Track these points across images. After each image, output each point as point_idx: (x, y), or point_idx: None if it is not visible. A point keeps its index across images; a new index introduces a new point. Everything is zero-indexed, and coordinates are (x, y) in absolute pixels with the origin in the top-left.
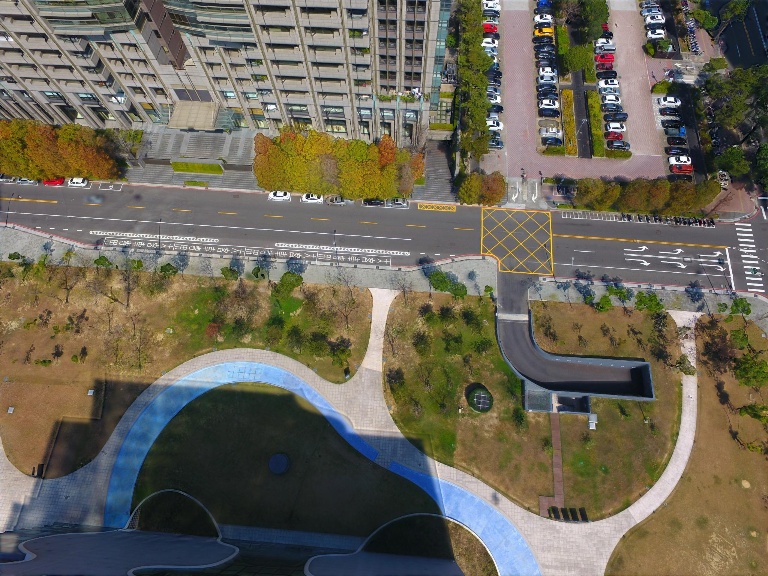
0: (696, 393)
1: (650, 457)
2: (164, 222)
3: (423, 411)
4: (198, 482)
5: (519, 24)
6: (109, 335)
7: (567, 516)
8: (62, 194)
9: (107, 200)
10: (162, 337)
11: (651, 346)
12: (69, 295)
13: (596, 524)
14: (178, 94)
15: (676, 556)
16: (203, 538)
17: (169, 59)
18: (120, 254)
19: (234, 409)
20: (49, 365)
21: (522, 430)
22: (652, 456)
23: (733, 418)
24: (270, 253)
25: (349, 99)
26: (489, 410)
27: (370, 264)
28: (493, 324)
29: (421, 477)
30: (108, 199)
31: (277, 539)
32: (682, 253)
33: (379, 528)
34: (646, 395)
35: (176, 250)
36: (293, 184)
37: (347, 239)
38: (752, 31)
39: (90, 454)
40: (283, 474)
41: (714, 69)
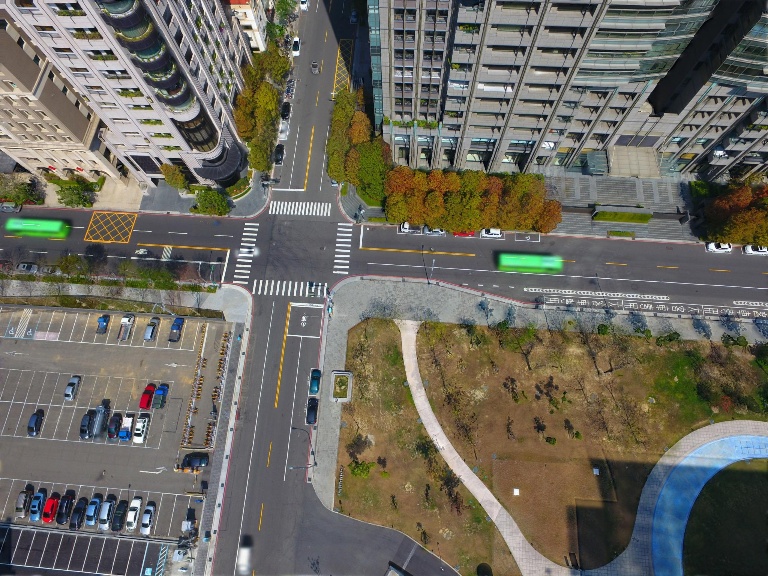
0: None
1: None
2: (601, 277)
3: None
4: (752, 573)
5: None
6: (588, 406)
7: None
8: (477, 246)
9: (529, 253)
10: (647, 408)
11: None
12: (529, 361)
13: None
14: (619, 140)
15: None
16: None
17: None
18: (568, 314)
19: (759, 489)
20: (536, 440)
21: None
22: None
23: None
24: (731, 312)
25: None
26: None
27: None
28: None
29: None
30: (530, 251)
31: None
32: None
33: None
34: None
35: (627, 309)
36: (763, 239)
37: None
38: None
39: (621, 541)
40: None
41: None
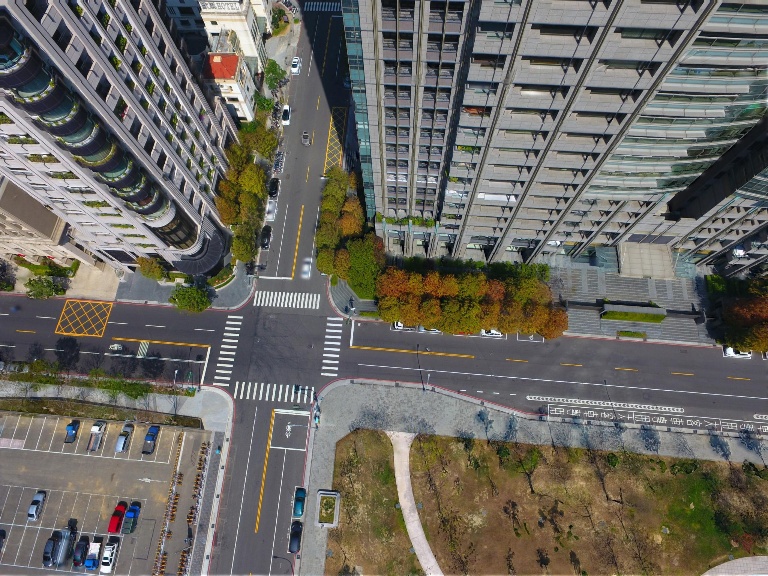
0: None
1: None
2: (611, 385)
3: None
4: None
5: None
6: (596, 536)
7: None
8: (476, 346)
9: (533, 355)
10: (660, 539)
11: None
12: (532, 482)
13: None
14: (631, 237)
15: None
16: None
17: None
18: (574, 427)
19: None
20: None
21: None
22: None
23: None
24: (752, 428)
25: None
26: None
27: None
28: None
29: None
30: (533, 353)
31: None
32: None
33: None
34: None
35: (638, 422)
36: None
37: None
38: None
39: None
40: None
41: None
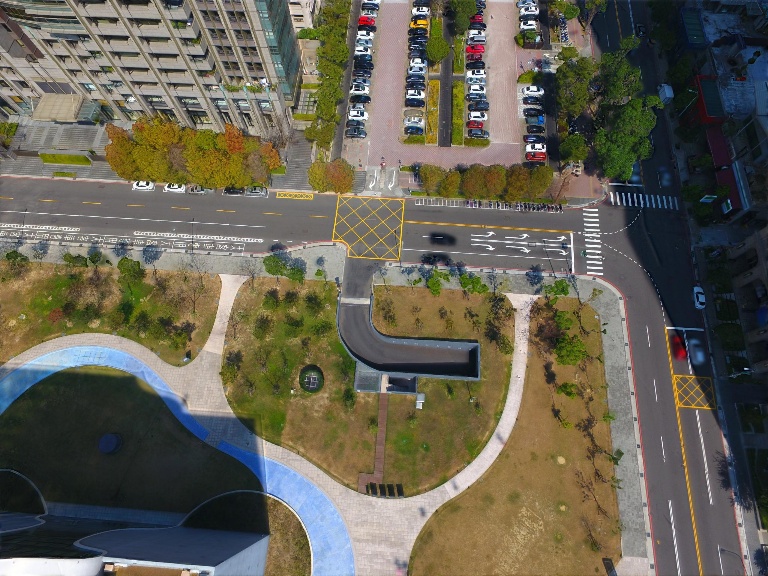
0: (524, 373)
1: (471, 435)
2: (29, 212)
3: (257, 392)
4: (32, 462)
5: (397, 17)
6: None
7: (384, 492)
8: None
9: None
10: (14, 323)
11: (486, 328)
12: None
13: (411, 499)
14: (41, 87)
15: (484, 530)
16: (26, 515)
17: (27, 52)
18: None
19: (75, 392)
20: None
21: (350, 410)
22: (473, 434)
23: (557, 397)
24: (128, 241)
25: (199, 90)
26: (318, 390)
27: (223, 251)
28: (335, 308)
29: (248, 455)
30: None
31: (101, 516)
32: (527, 238)
33: (200, 504)
34: (472, 375)
35: (37, 239)
36: (148, 173)
37: (204, 227)
38: (624, 21)
39: None
40: (114, 453)
41: (566, 58)
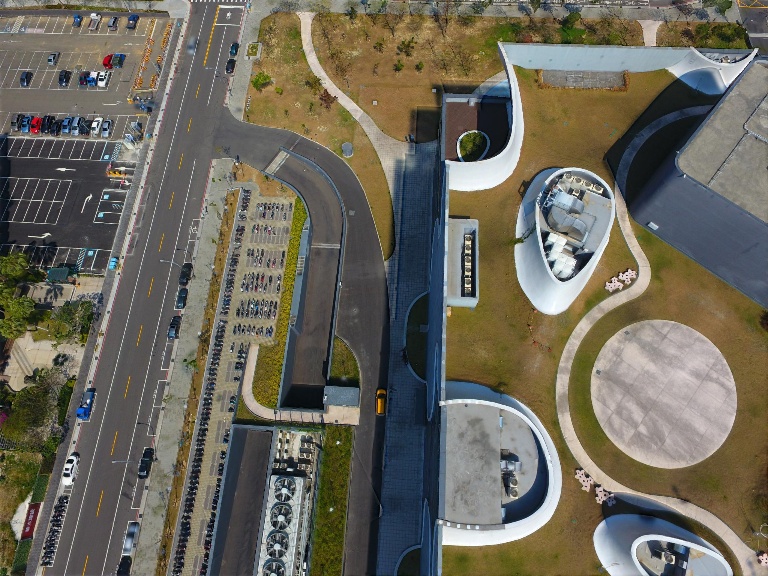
0: None
1: None
2: None
3: None
4: None
5: None
6: (434, 57)
7: None
8: None
9: None
10: (478, 57)
11: None
12: (394, 32)
13: None
14: None
15: None
16: None
17: None
18: (426, 5)
19: None
20: (393, 76)
21: None
22: None
23: None
24: (549, 1)
25: None
26: None
27: (633, 5)
28: (743, 40)
29: None
30: None
31: None
32: None
33: None
34: None
35: (471, 1)
36: None
37: None
38: None
39: None
40: None
41: None
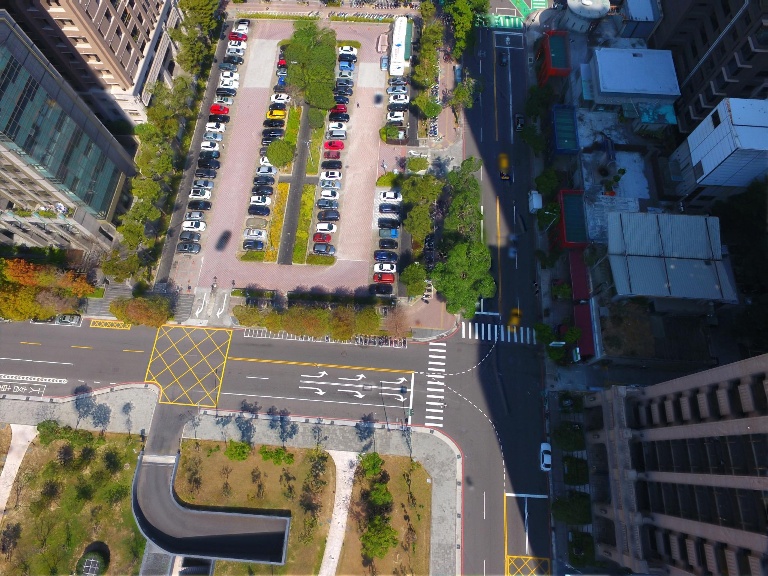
0: (339, 552)
1: None
2: None
3: None
4: None
5: (254, 104)
6: None
7: None
8: None
9: None
10: None
11: (302, 495)
12: None
13: None
14: None
15: None
16: None
17: None
18: None
19: None
20: None
21: None
22: None
23: None
24: None
25: None
26: None
27: (21, 394)
28: None
29: None
30: None
31: None
32: (363, 380)
33: None
34: (276, 559)
35: None
36: None
37: (3, 363)
38: (502, 111)
39: None
40: None
41: (416, 169)
